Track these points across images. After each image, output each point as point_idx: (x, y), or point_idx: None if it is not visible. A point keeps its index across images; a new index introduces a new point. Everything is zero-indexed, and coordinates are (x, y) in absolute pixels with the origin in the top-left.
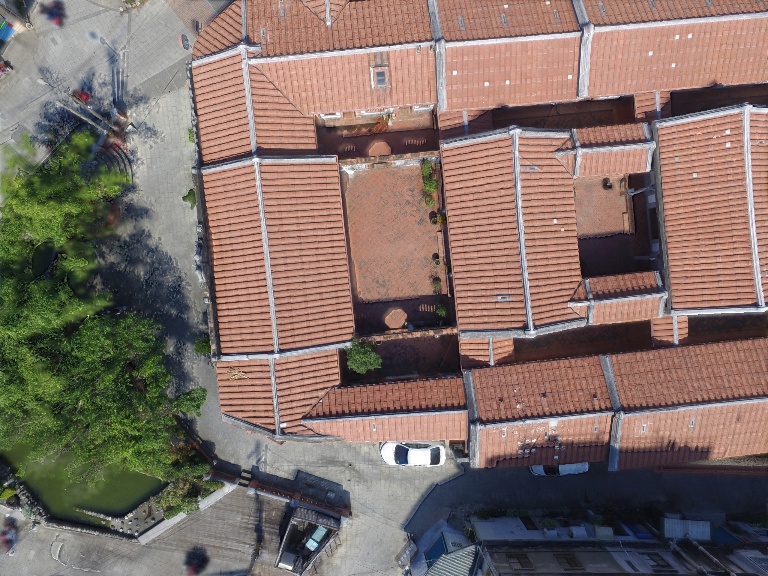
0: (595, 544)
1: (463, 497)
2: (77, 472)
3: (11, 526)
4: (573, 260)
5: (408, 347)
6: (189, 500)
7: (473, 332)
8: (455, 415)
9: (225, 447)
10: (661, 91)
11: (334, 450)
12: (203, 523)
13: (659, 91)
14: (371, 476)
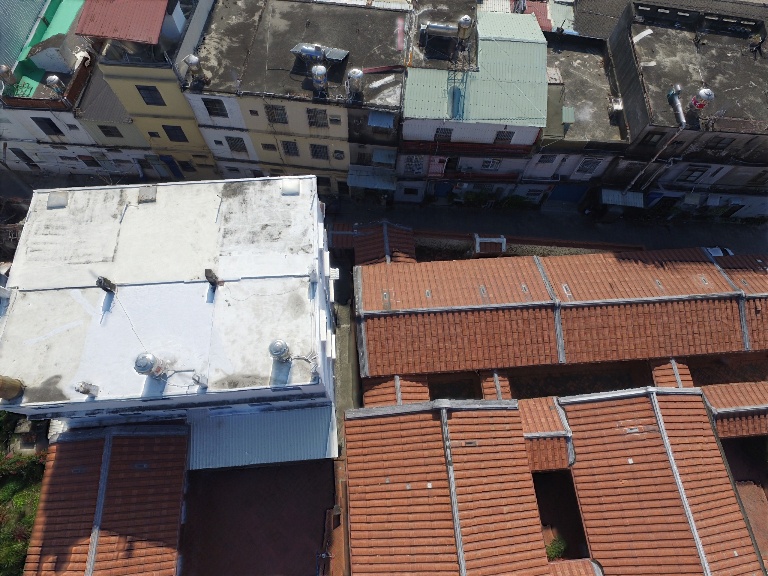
0: (714, 191)
1: None
2: None
3: None
4: None
5: None
6: None
7: None
8: None
9: None
10: None
11: None
12: None
13: None
14: None
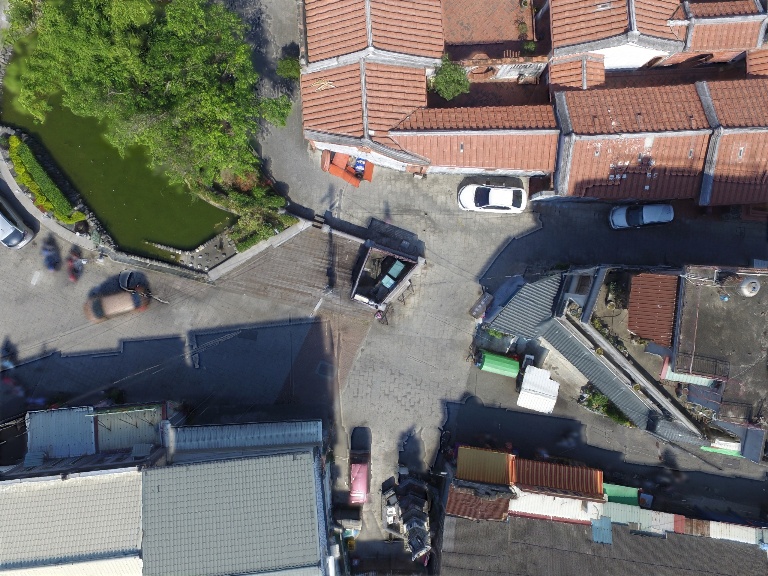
0: None
1: (540, 253)
2: (147, 205)
3: (77, 257)
4: None
5: (490, 94)
6: (266, 224)
7: (569, 46)
8: (545, 137)
9: (299, 190)
10: None
11: (410, 198)
12: (274, 263)
13: None
14: (447, 227)
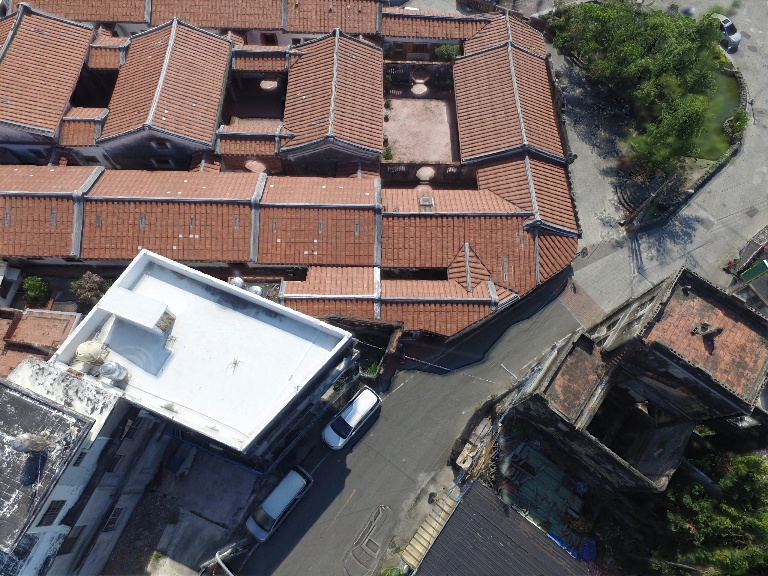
0: None
1: None
2: None
3: None
4: None
5: None
6: (561, 5)
7: (373, 46)
8: None
9: None
10: None
11: None
12: (550, 5)
13: None
14: None
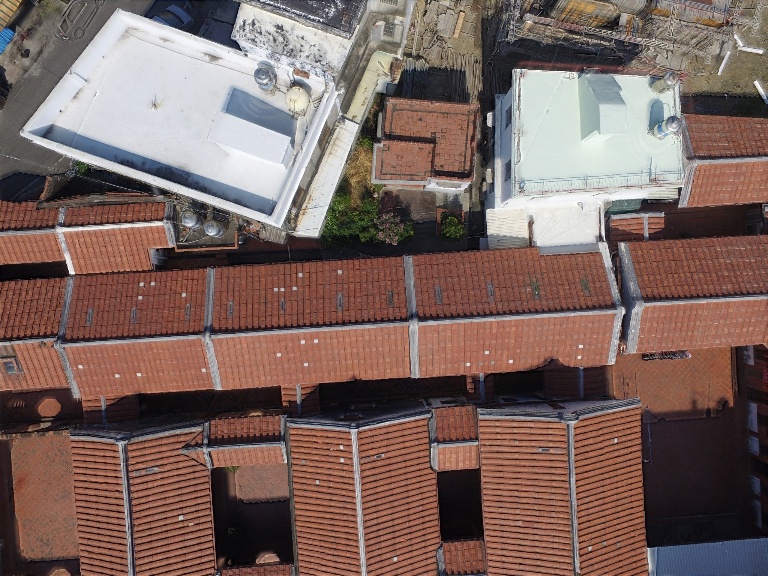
0: None
1: None
2: None
3: None
4: (205, 553)
5: None
6: None
7: None
8: None
9: None
10: (301, 384)
11: None
12: None
13: (299, 384)
14: None
